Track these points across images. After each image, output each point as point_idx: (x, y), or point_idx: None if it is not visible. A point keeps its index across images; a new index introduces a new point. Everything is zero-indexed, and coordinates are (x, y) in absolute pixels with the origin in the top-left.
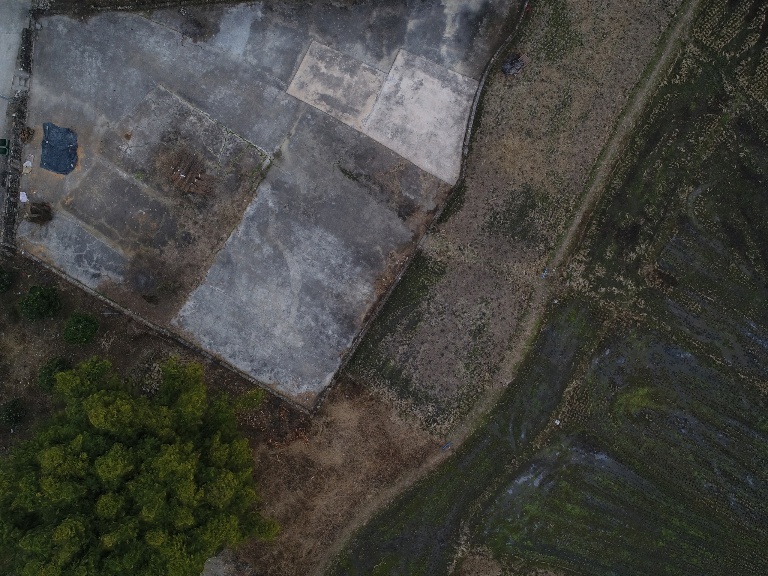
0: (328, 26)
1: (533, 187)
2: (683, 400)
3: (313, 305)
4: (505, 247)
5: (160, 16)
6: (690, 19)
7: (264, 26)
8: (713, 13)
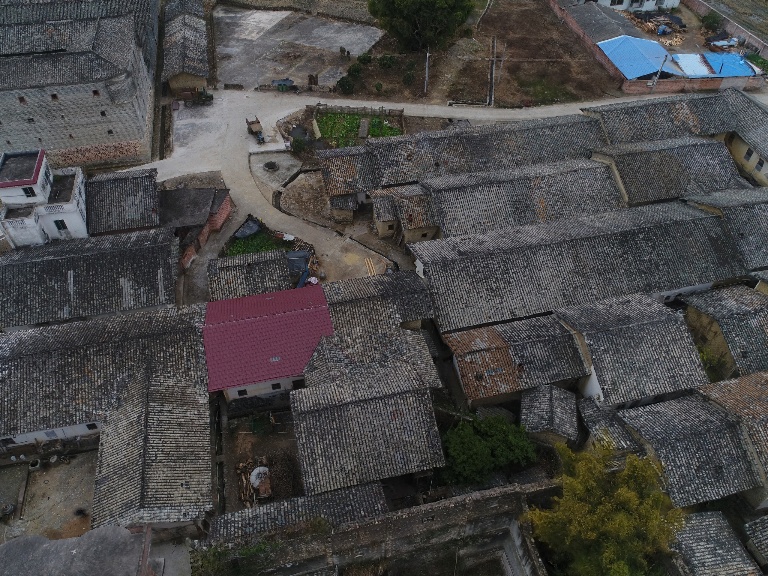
0: (228, 34)
1: (292, 2)
2: None
3: None
4: (315, 5)
5: None
6: None
7: (226, 45)
8: None
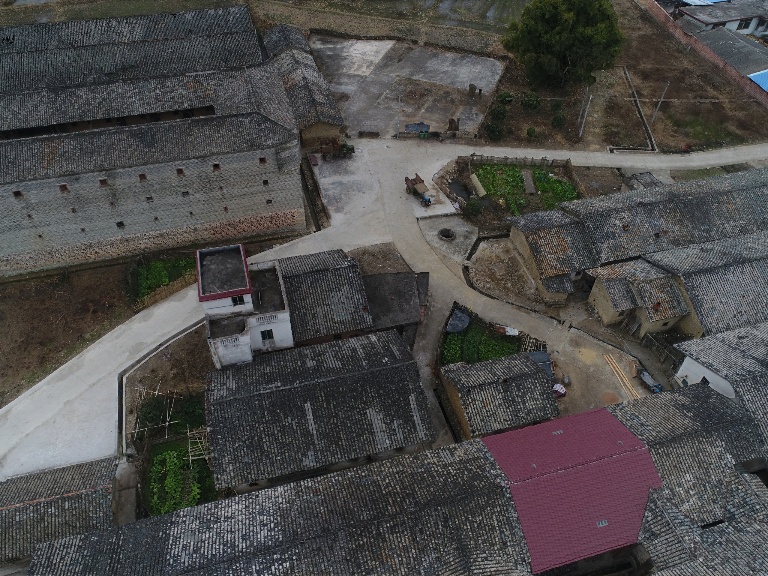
0: (335, 69)
1: None
2: (458, 4)
3: (461, 64)
4: None
5: (340, 107)
6: (316, 8)
7: None
8: (312, 6)
